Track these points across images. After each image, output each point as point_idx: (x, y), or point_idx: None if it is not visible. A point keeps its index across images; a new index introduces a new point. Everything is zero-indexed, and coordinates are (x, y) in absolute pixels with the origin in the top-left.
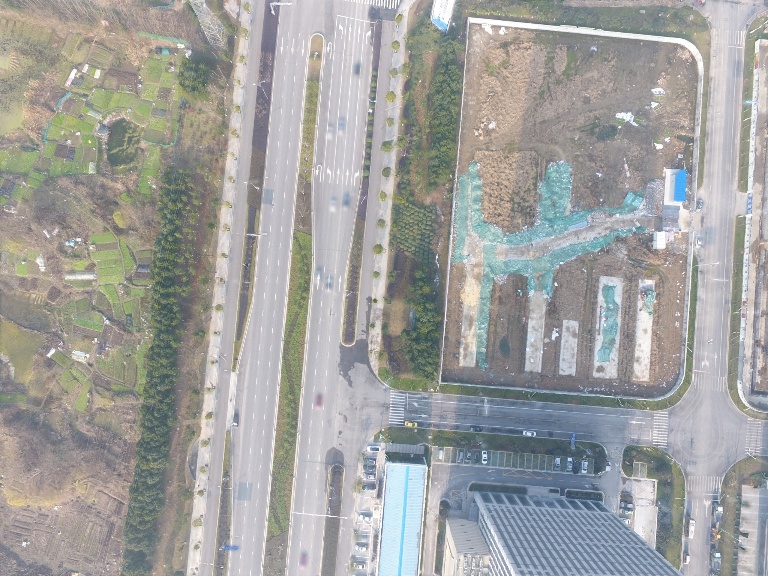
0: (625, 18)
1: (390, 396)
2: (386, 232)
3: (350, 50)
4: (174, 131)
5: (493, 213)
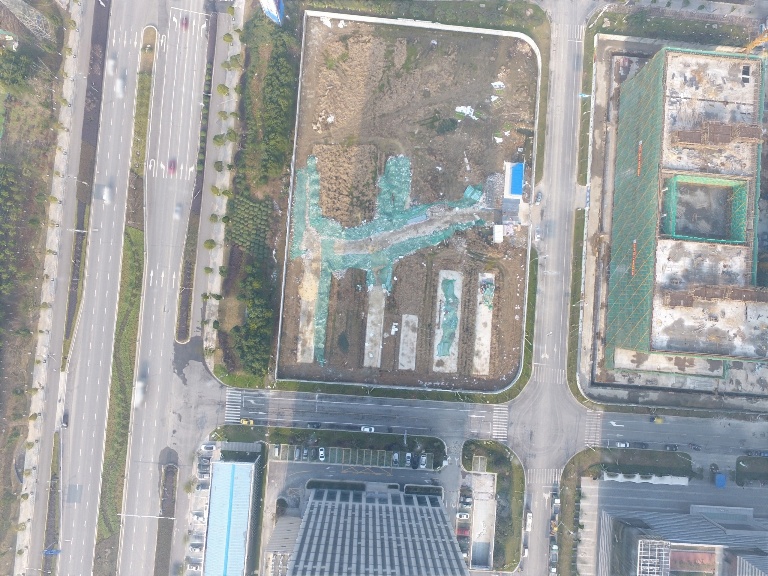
0: (459, 11)
1: (226, 394)
2: (221, 227)
3: (184, 43)
4: (1, 125)
5: (331, 207)
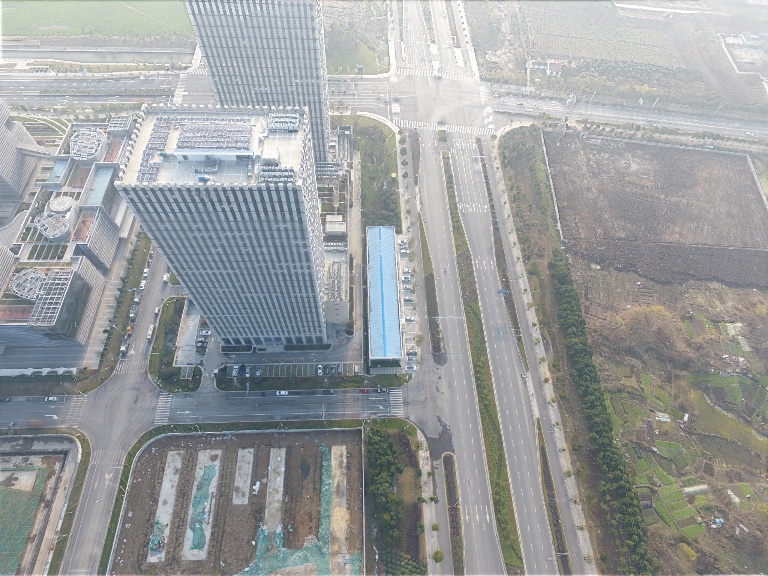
0: None
1: (404, 412)
2: None
3: None
4: None
5: None
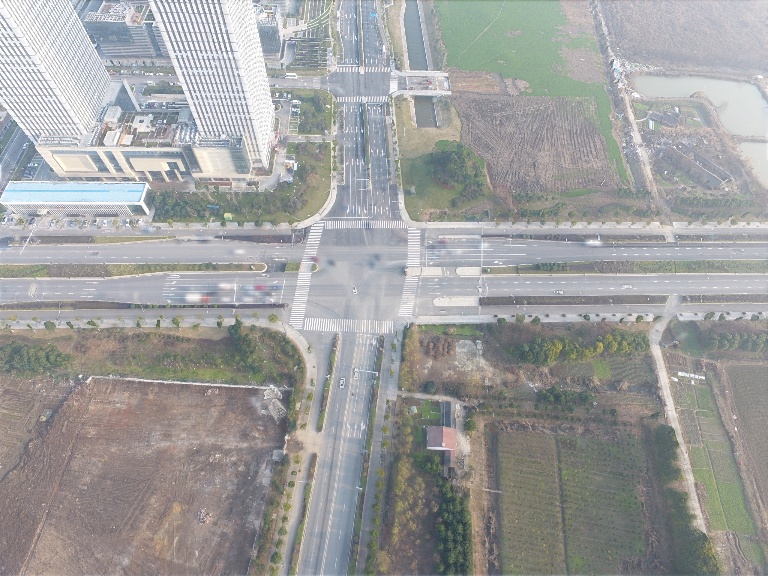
0: None
1: None
2: None
3: None
4: None
5: None
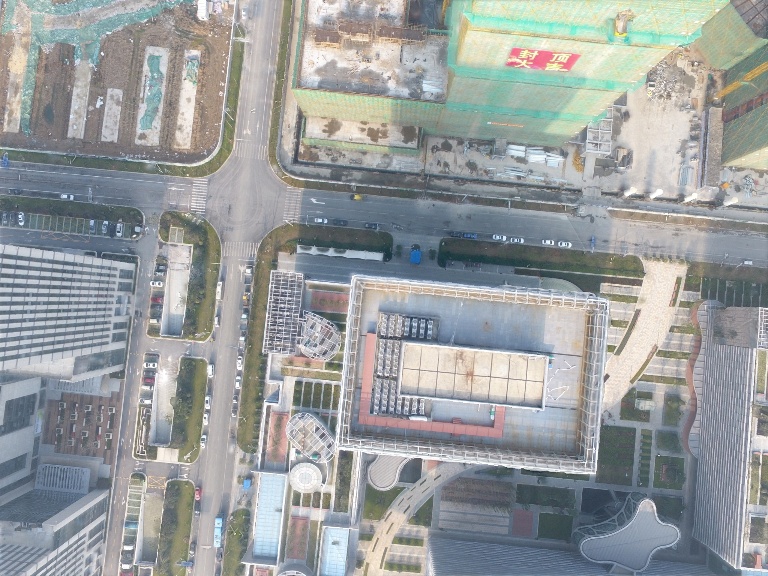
0: None
1: None
2: None
3: None
4: None
5: None
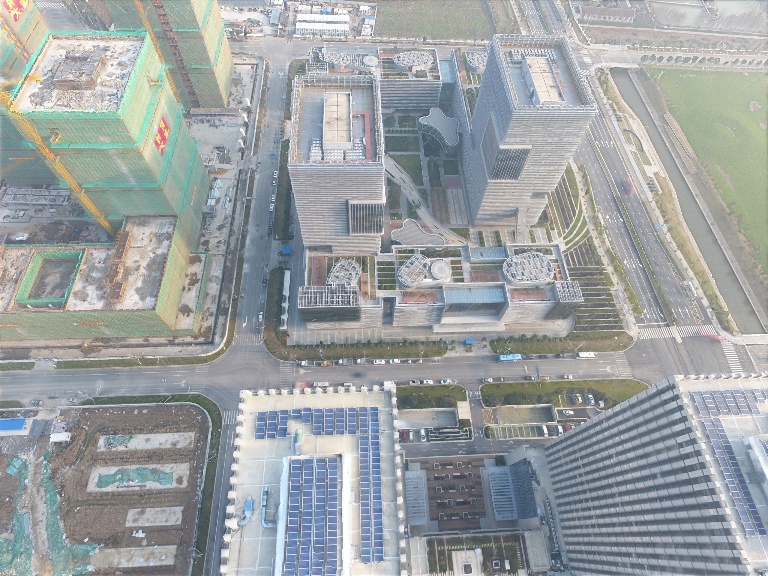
0: None
1: None
2: None
3: None
4: None
5: None
